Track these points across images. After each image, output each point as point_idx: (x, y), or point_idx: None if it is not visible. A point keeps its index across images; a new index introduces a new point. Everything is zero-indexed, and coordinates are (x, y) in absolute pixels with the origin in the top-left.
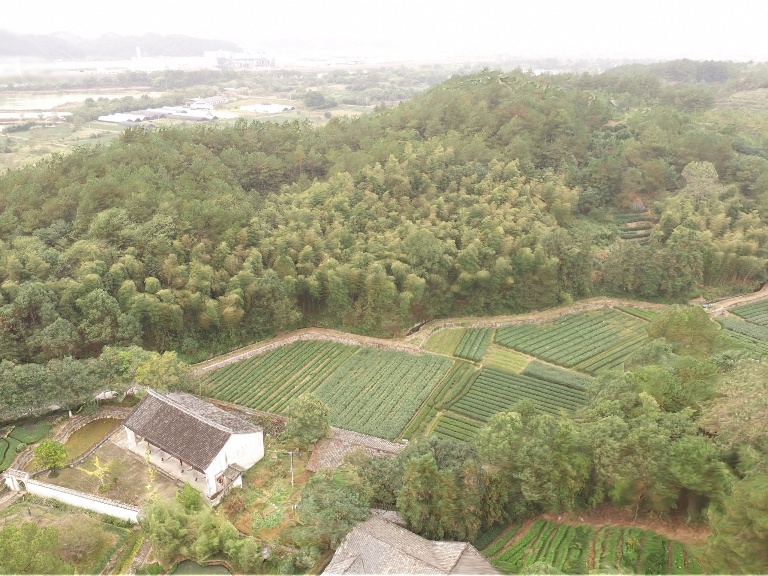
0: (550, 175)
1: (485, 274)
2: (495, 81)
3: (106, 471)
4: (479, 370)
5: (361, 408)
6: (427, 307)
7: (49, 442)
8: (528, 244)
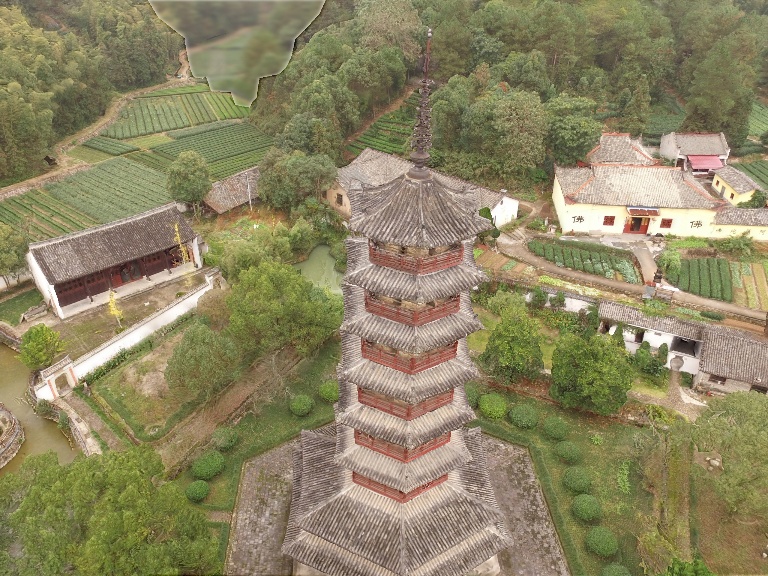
0: None
1: (72, 81)
2: None
3: (117, 309)
4: (153, 150)
5: (146, 198)
6: None
7: (41, 324)
8: (66, 51)
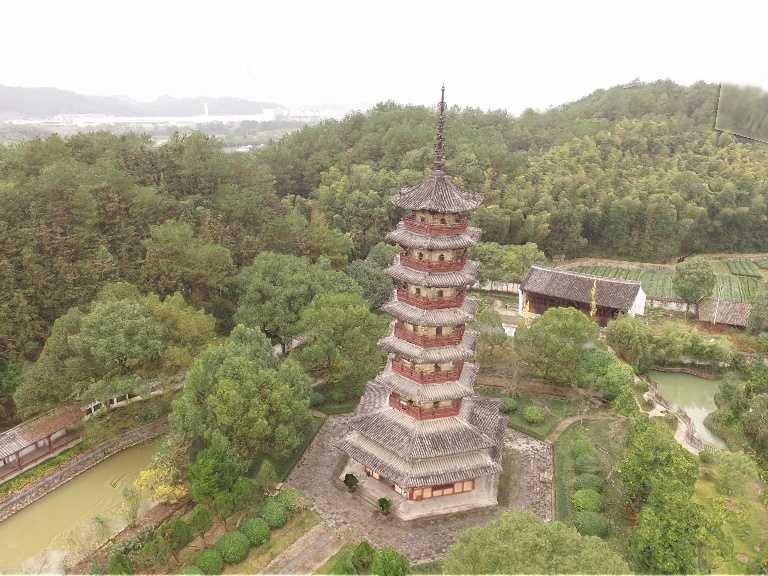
0: (756, 146)
1: (747, 209)
2: (662, 82)
3: None
4: None
5: None
6: (692, 240)
7: None
8: None
